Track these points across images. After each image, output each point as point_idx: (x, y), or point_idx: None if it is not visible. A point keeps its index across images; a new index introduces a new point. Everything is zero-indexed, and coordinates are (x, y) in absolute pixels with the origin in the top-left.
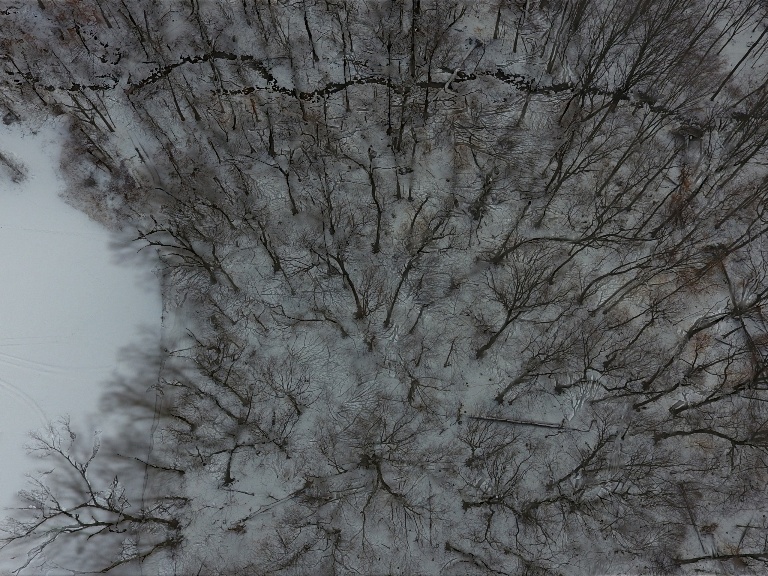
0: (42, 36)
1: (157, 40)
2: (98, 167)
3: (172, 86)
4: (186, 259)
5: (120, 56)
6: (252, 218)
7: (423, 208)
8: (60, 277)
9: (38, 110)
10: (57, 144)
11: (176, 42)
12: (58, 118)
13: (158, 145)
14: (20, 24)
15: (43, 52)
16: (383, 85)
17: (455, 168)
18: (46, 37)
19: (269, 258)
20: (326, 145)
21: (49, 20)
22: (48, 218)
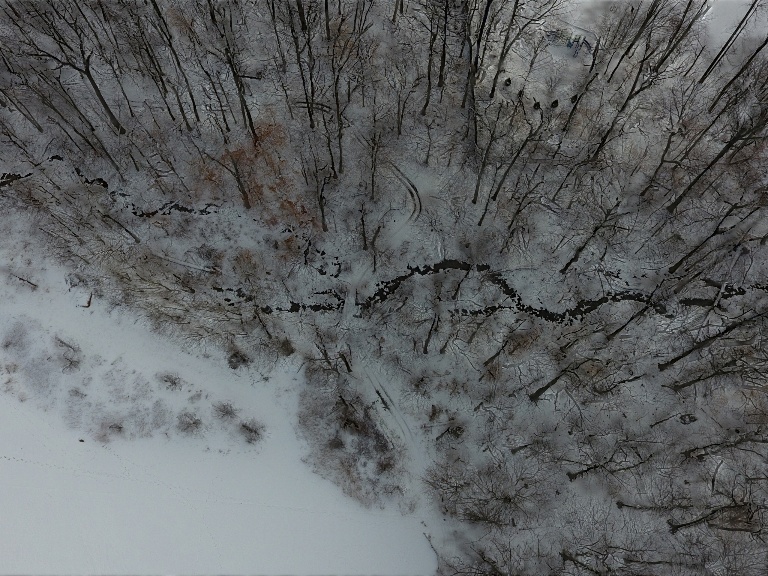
0: (250, 242)
1: (389, 255)
2: (345, 425)
3: (410, 311)
4: (488, 575)
5: (340, 266)
6: (524, 486)
7: (719, 472)
8: (318, 572)
9: (264, 346)
10: (292, 393)
11: (402, 249)
12: (290, 359)
13: (402, 387)
14: (224, 227)
15: (256, 266)
16: (642, 302)
17: (745, 416)
18: (255, 244)
19: (555, 543)
20: (593, 386)
21: (255, 221)
22: (293, 491)
